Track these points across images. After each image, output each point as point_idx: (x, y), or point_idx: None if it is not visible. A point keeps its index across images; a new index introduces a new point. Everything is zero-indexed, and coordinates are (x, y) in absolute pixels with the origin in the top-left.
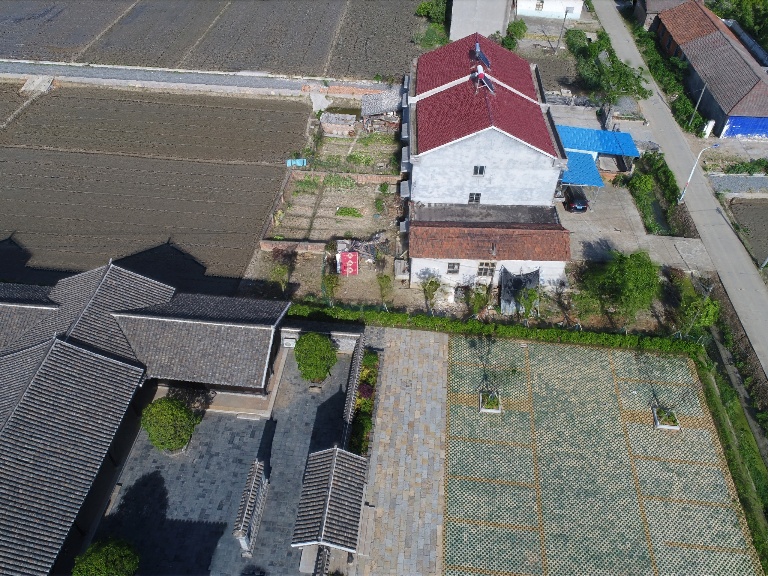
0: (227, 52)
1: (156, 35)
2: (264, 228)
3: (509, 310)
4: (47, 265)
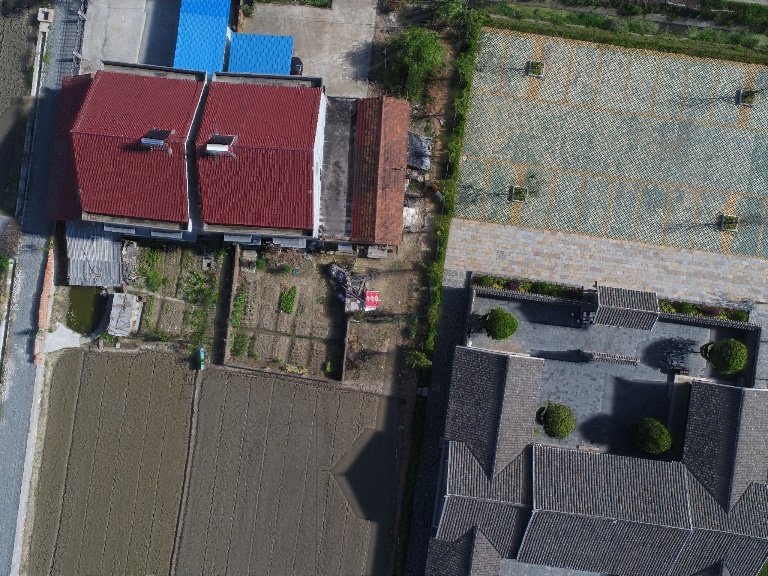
0: None
1: None
2: None
3: (428, 163)
4: (359, 572)
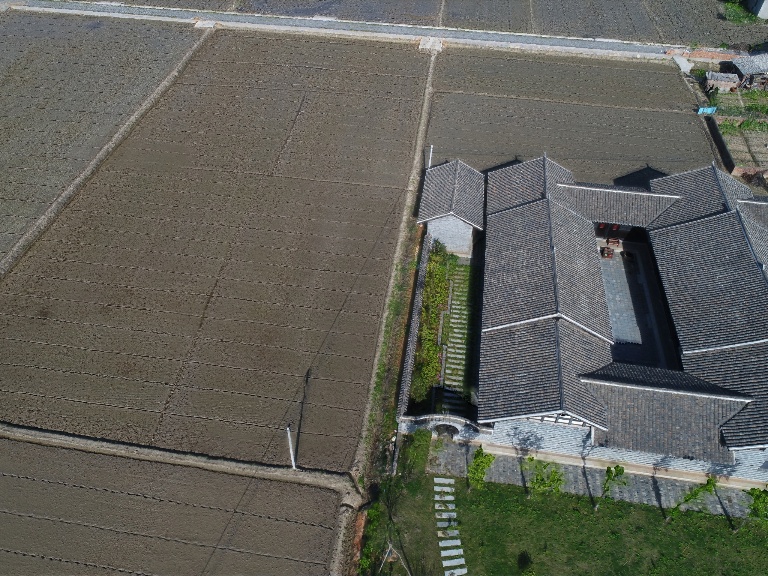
0: (564, 23)
1: (490, 7)
2: (729, 157)
3: None
4: None
